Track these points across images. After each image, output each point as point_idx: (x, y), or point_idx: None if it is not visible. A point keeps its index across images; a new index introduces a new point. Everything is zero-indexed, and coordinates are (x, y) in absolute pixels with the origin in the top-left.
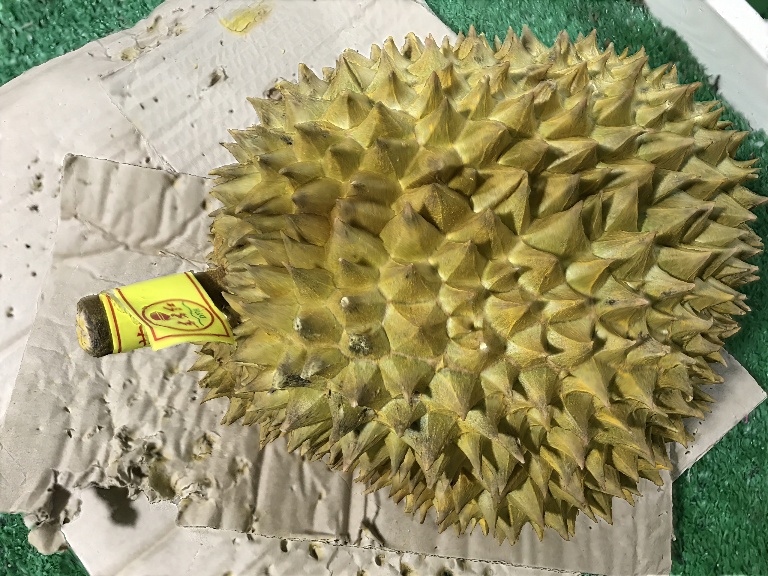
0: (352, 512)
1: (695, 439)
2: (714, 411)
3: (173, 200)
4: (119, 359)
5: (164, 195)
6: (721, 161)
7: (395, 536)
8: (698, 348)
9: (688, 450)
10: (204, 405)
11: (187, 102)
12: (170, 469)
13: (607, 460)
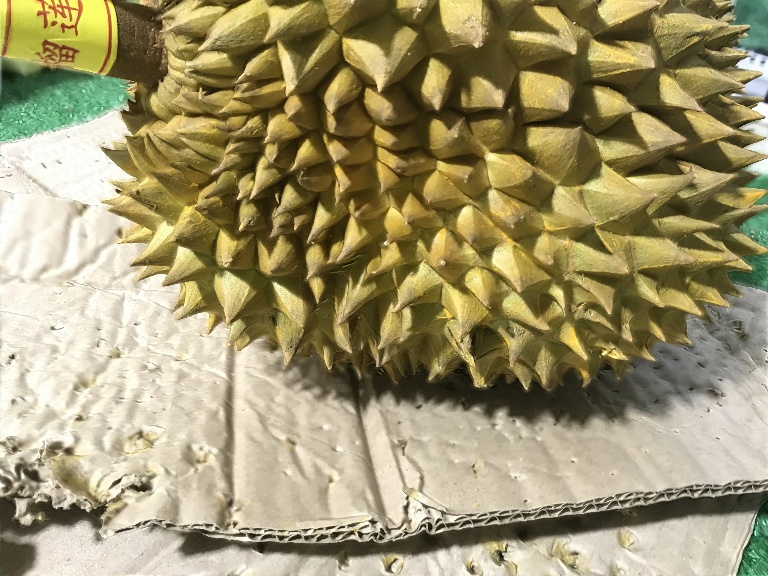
0: (384, 494)
1: None
2: None
3: (82, 228)
4: (7, 378)
5: (71, 224)
6: None
7: (459, 499)
8: None
9: None
10: (136, 406)
11: (95, 165)
12: (87, 466)
13: (685, 131)
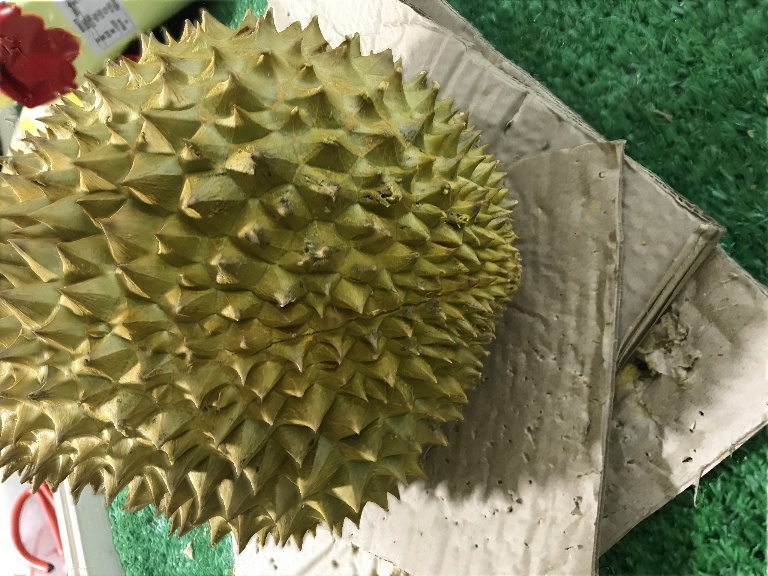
0: None
1: (695, 439)
2: (724, 394)
3: None
4: None
5: None
6: (192, 136)
7: None
8: (133, 379)
9: (689, 456)
10: None
11: None
12: None
13: None
